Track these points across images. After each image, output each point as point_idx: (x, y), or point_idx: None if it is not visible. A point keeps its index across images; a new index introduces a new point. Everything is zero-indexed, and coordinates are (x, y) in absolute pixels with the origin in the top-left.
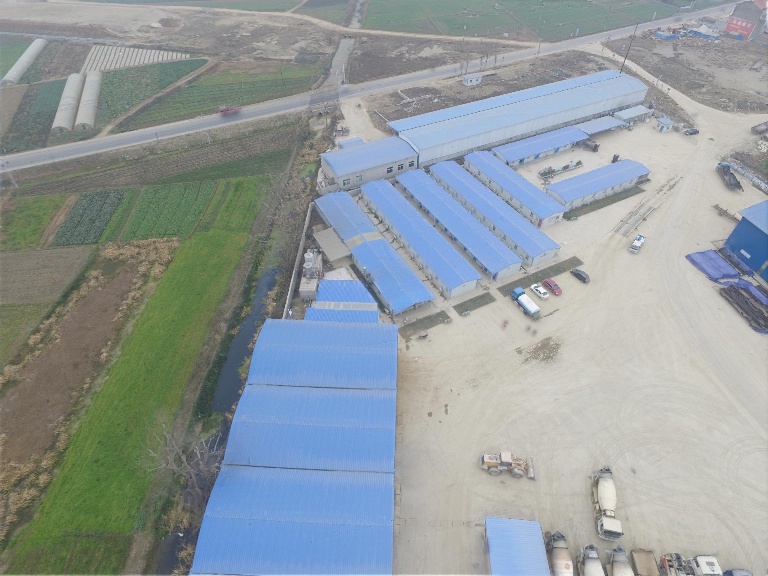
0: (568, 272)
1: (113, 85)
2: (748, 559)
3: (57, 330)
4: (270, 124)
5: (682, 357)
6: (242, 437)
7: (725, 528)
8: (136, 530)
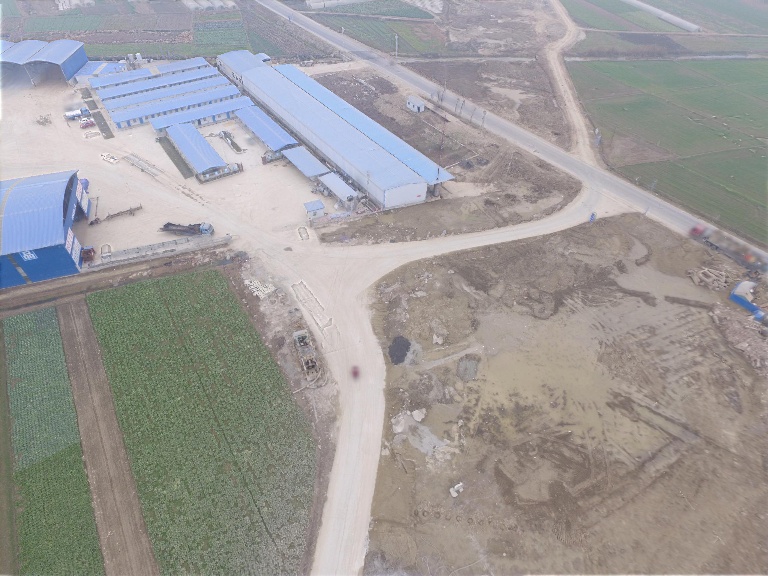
0: (100, 133)
1: (372, 3)
2: None
3: (136, 33)
4: (320, 46)
5: (4, 159)
6: None
7: None
8: None
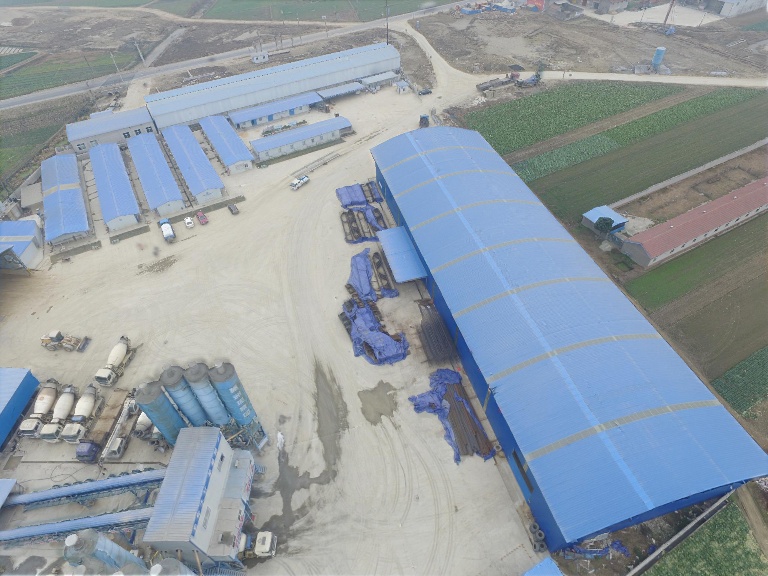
0: (227, 207)
1: None
2: None
3: None
4: (57, 104)
5: (270, 264)
6: None
7: None
8: None
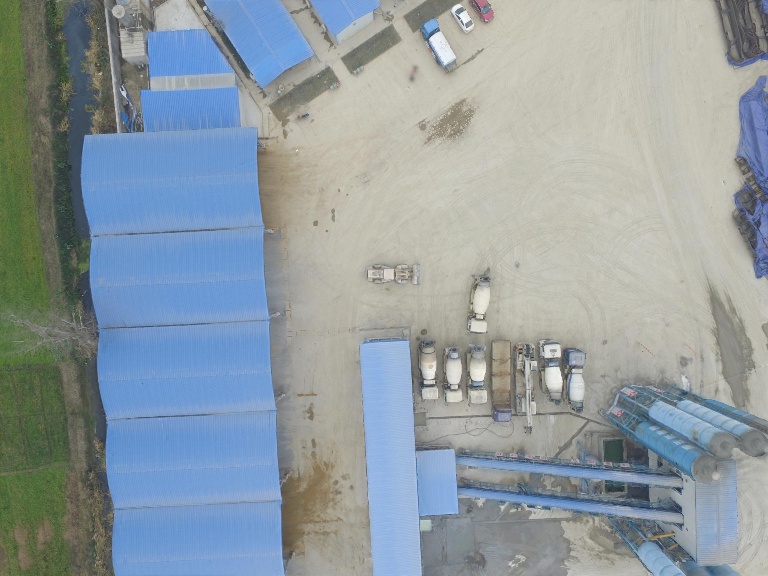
0: None
1: None
2: (592, 334)
3: None
4: None
5: (619, 115)
6: (107, 303)
7: (583, 310)
8: (58, 362)
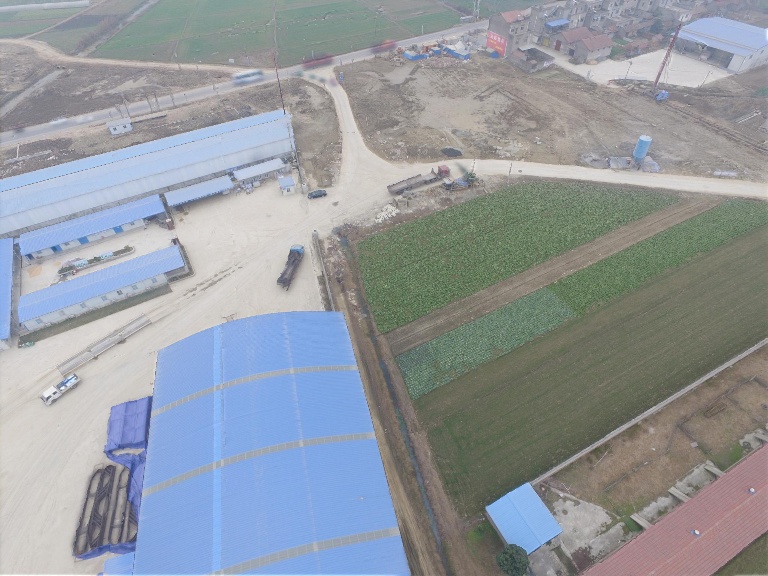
0: None
1: None
2: None
3: None
4: None
5: None
6: None
7: None
8: None
